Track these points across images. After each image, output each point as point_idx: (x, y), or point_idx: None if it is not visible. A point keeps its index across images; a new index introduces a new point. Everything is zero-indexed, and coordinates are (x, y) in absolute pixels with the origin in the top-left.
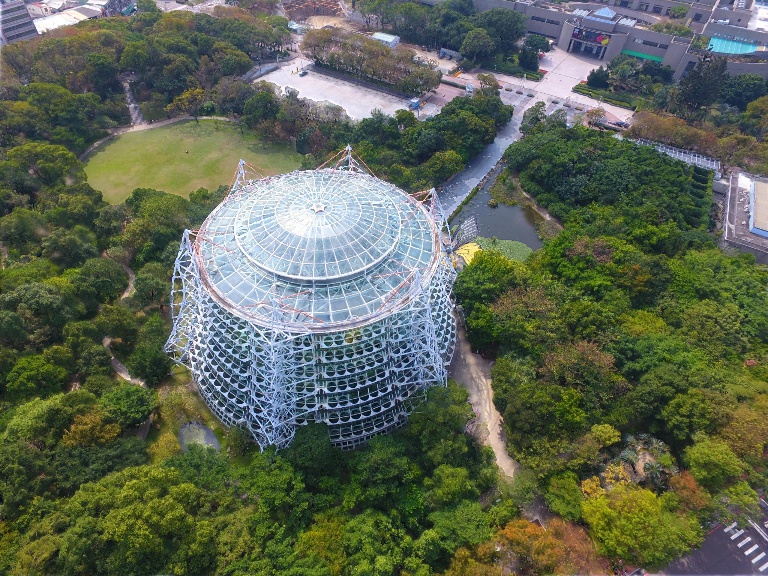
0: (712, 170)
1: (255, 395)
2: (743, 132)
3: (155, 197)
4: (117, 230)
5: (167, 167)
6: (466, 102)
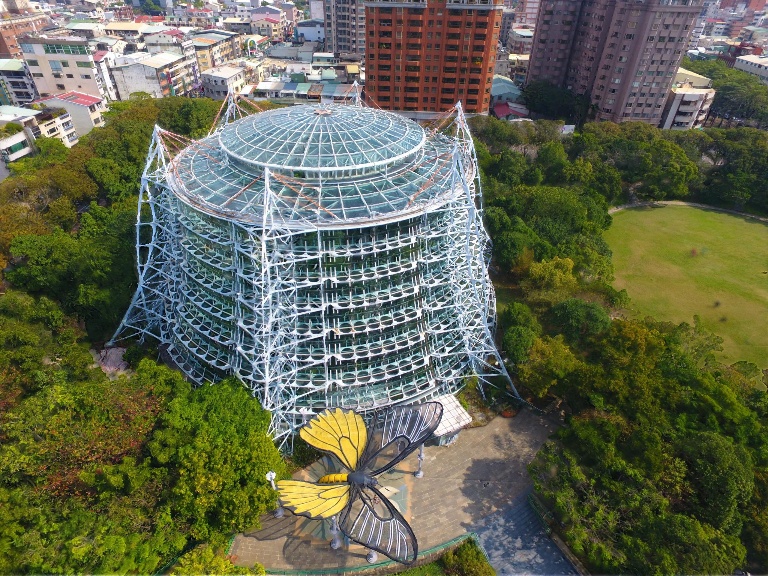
0: None
1: None
2: None
3: None
4: None
5: (713, 254)
6: None
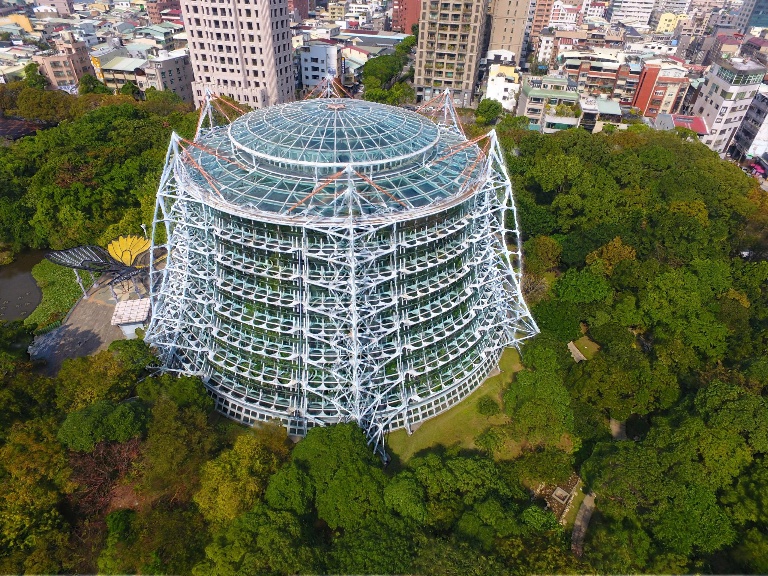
0: None
1: None
2: None
3: None
4: None
5: None
6: None
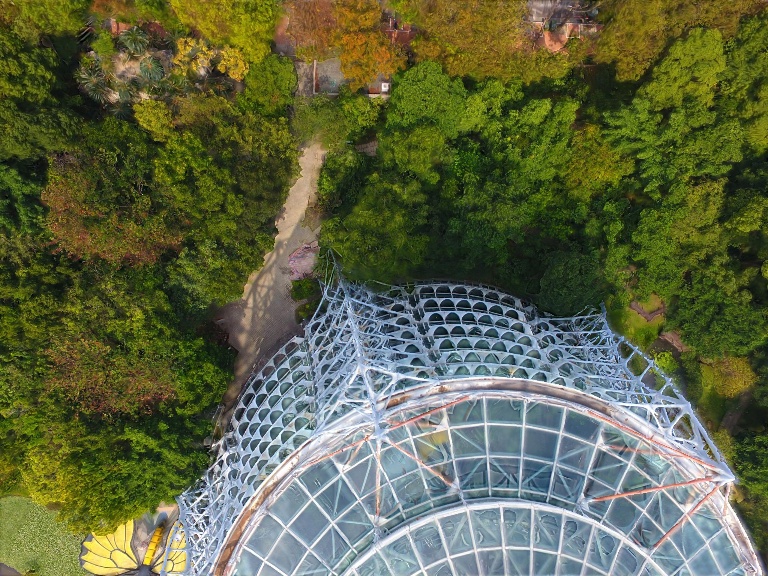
0: None
1: None
2: None
3: None
4: None
5: None
6: None
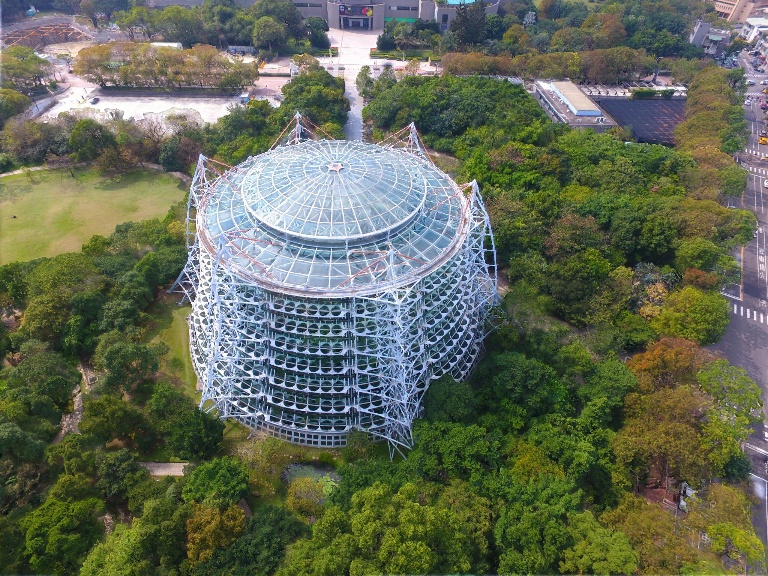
0: (520, 84)
1: (360, 388)
2: (514, 55)
3: (43, 264)
4: (1, 328)
5: None
6: (307, 79)
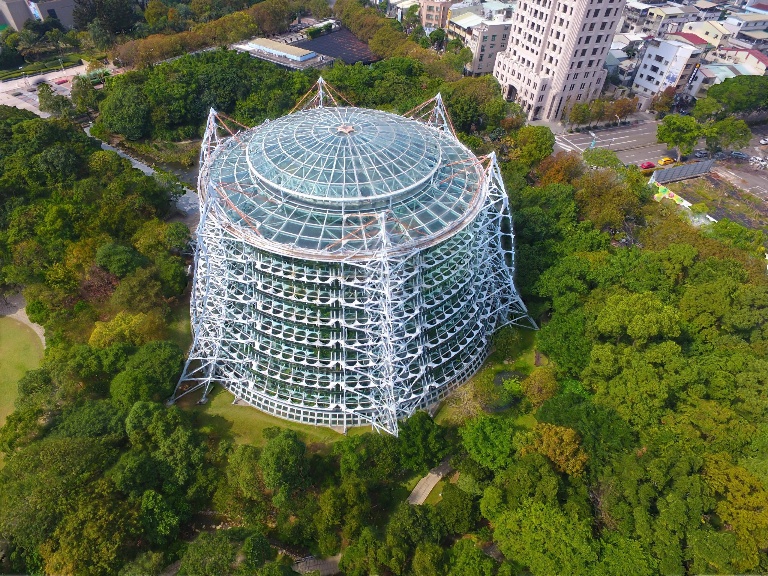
0: None
1: None
2: (175, 32)
3: (6, 492)
4: None
5: None
6: None
